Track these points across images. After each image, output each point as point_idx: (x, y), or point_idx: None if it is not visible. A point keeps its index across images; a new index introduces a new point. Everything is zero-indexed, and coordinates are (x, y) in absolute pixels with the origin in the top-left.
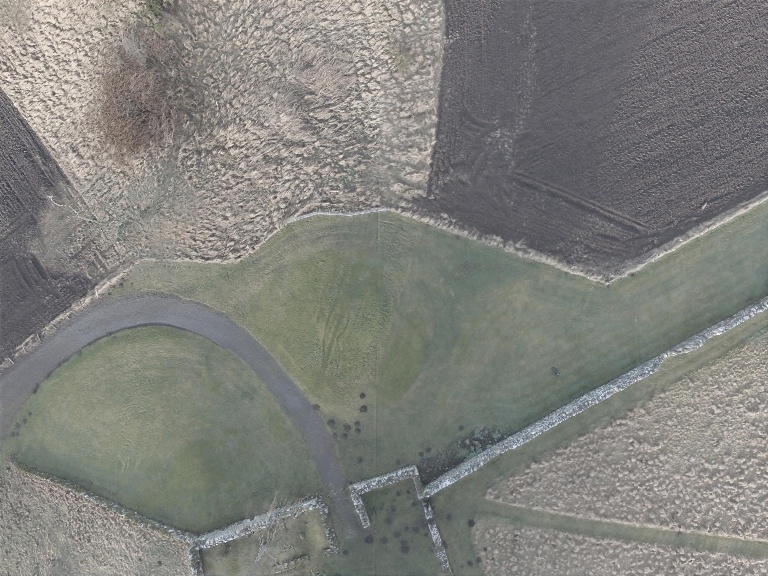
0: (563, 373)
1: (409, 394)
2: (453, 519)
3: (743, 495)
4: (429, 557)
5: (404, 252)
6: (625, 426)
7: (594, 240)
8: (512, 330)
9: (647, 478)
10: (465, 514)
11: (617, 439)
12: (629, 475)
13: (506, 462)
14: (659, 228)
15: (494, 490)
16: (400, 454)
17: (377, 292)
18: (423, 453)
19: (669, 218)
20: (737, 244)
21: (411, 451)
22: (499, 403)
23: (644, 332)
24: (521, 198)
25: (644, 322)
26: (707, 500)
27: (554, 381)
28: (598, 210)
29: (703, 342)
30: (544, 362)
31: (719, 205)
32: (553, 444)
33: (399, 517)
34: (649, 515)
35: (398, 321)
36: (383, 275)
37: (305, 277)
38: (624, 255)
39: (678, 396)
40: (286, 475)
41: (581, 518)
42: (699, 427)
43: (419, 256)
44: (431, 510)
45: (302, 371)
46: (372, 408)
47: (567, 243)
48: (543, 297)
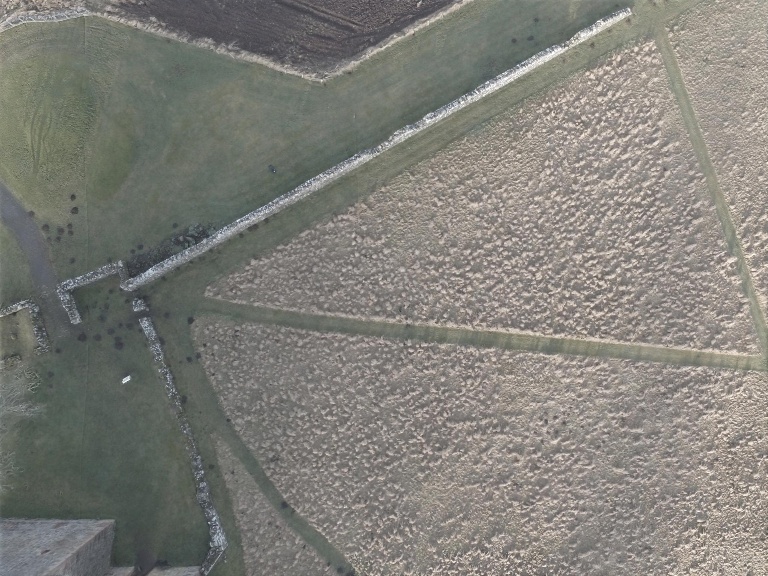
0: (280, 170)
1: (120, 194)
2: (171, 317)
3: (470, 285)
4: (143, 352)
5: (112, 56)
6: (347, 221)
7: (309, 40)
8: (228, 130)
9: (372, 272)
10: (184, 312)
11: (340, 235)
12: (353, 270)
13: (226, 260)
14: (375, 27)
15: (213, 287)
16: (112, 252)
17: (81, 93)
18: (135, 250)
19: (384, 16)
20: (454, 40)
21: (122, 249)
22: (215, 201)
23: (362, 128)
24: (232, 1)
25: (362, 118)
26: (434, 292)
27: (271, 178)
28: (312, 11)
29: (412, 129)
30: (261, 161)
31: (435, 2)
32: (274, 242)
33: (112, 314)
34: (375, 308)
35: (105, 121)
36: (89, 77)
37: (13, 84)
38: (341, 54)
39: (399, 190)
40: (2, 282)
41: (305, 313)
42: (423, 220)
43: (128, 59)
44: (141, 304)
45: (16, 179)
46: (83, 209)
47: (282, 44)
48: (259, 98)
